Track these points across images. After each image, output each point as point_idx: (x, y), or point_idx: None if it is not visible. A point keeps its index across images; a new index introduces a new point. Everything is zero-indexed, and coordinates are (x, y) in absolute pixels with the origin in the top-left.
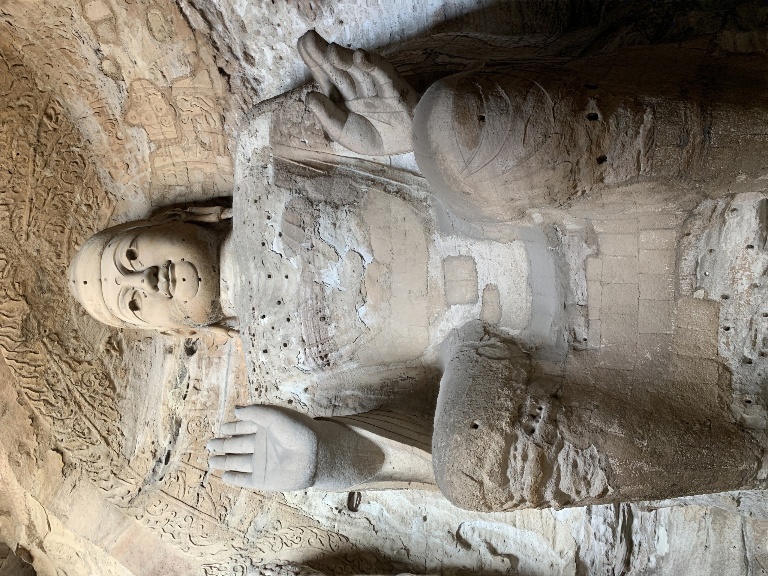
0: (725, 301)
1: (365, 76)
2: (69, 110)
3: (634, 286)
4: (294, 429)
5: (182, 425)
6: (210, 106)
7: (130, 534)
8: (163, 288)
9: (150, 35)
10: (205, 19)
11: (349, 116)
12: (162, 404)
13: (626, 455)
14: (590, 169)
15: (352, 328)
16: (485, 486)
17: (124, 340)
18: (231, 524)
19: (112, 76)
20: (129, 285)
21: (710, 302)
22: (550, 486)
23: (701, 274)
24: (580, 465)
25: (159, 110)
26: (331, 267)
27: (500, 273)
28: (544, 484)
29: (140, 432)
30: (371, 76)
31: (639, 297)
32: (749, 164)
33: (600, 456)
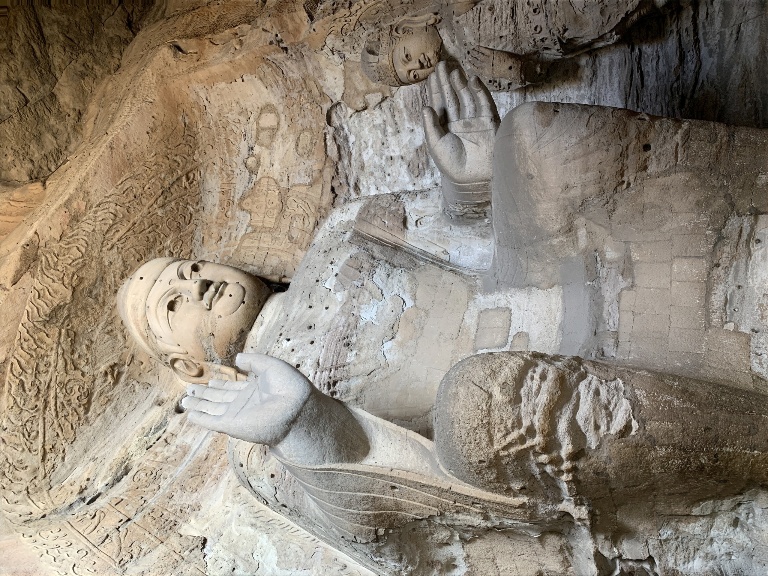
0: (755, 333)
1: (471, 102)
2: (204, 182)
3: (665, 316)
4: (292, 374)
5: (130, 472)
6: (311, 211)
7: (6, 544)
8: (208, 296)
9: (295, 148)
10: (339, 152)
11: (448, 134)
12: (122, 446)
13: (654, 388)
14: (637, 155)
15: (372, 359)
16: (494, 399)
17: (126, 374)
18: (129, 572)
19: (250, 170)
20: (180, 287)
21: (740, 333)
22: (566, 412)
23: (730, 310)
24: (603, 394)
25: (270, 203)
26: (373, 304)
27: (533, 322)
28: (560, 407)
29: (82, 464)
30: (475, 104)
31: (670, 325)
32: (767, 162)
33: (626, 388)
